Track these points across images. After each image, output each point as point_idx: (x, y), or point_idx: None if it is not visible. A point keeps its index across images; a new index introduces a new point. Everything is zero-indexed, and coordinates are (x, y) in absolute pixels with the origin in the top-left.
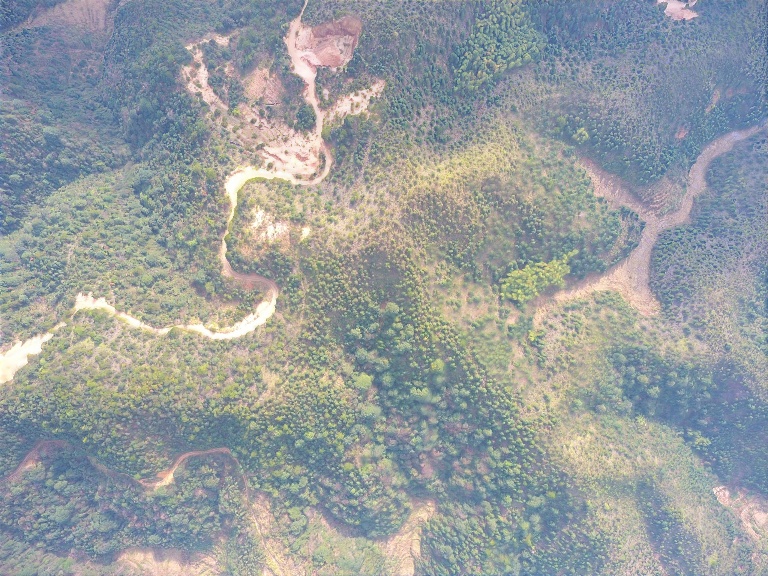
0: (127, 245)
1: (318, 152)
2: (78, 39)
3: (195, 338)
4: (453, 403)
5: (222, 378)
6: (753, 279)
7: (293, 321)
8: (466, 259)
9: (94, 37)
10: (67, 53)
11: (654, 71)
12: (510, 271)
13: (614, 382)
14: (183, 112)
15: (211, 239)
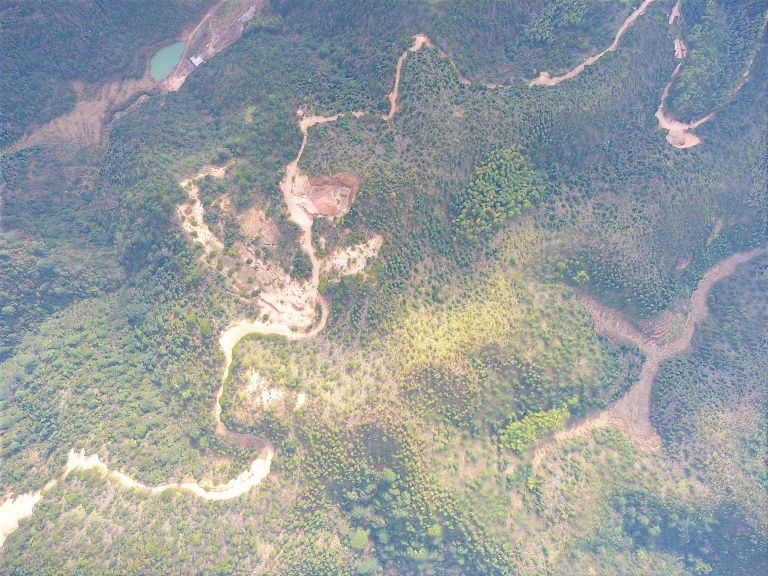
0: (121, 389)
1: (314, 303)
2: (73, 156)
3: (189, 500)
4: (451, 558)
5: (216, 550)
6: (755, 416)
7: (288, 487)
8: (464, 418)
9: (89, 152)
10: (62, 173)
11: (655, 210)
12: (509, 423)
13: (614, 522)
14: (178, 251)
15: (205, 395)
